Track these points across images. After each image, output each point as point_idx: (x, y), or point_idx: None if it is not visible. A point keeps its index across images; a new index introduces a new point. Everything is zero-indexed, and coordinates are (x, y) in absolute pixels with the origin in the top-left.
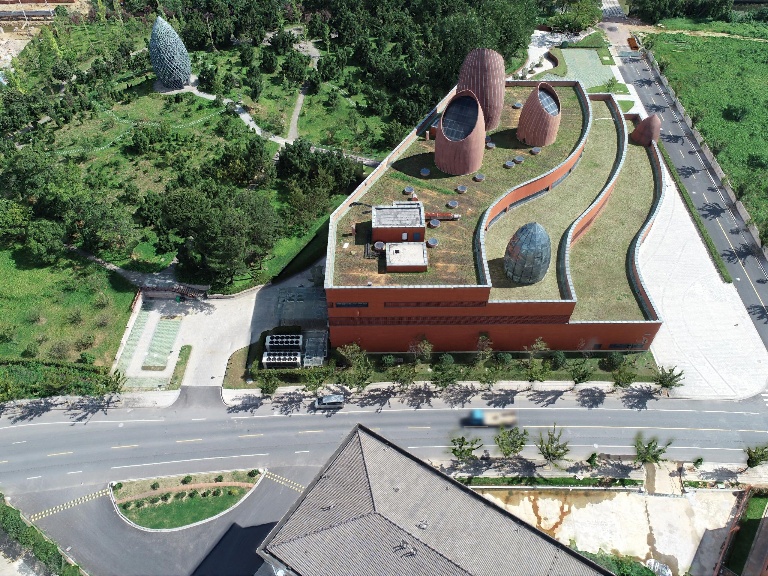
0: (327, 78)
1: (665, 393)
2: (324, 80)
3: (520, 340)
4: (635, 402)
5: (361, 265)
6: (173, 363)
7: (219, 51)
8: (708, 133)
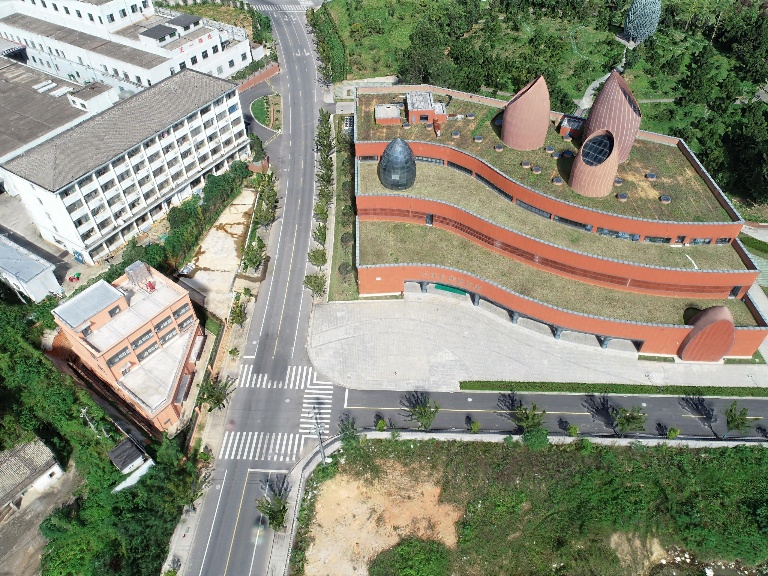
0: (713, 107)
1: (317, 301)
2: None
3: None
4: None
5: (382, 102)
6: (352, 97)
7: (716, 49)
8: None
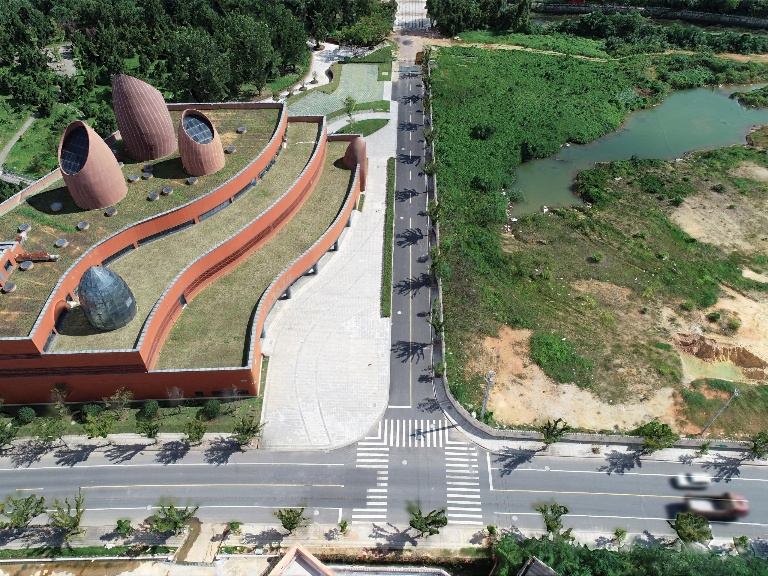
0: (67, 99)
1: (255, 444)
2: (65, 101)
3: (109, 390)
4: (218, 455)
5: None
6: None
7: None
8: (444, 153)
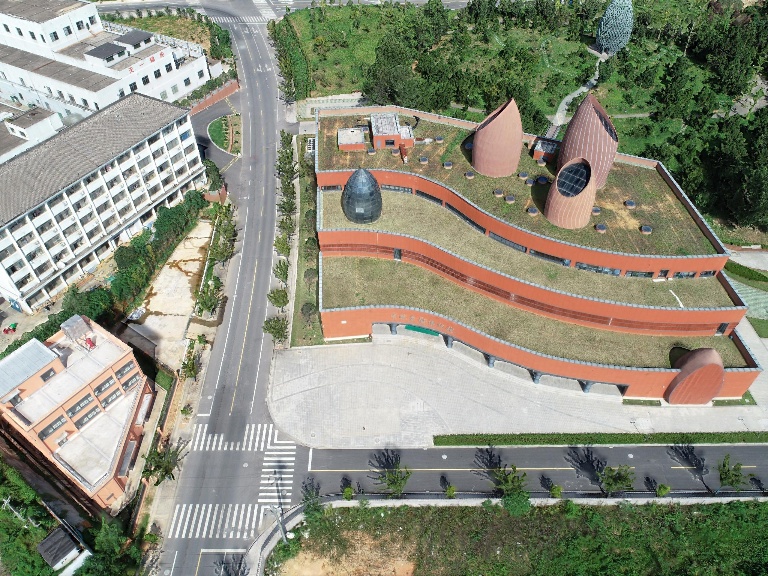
0: (689, 122)
1: (279, 347)
2: None
3: None
4: None
5: (346, 125)
6: None
7: (690, 59)
8: None
